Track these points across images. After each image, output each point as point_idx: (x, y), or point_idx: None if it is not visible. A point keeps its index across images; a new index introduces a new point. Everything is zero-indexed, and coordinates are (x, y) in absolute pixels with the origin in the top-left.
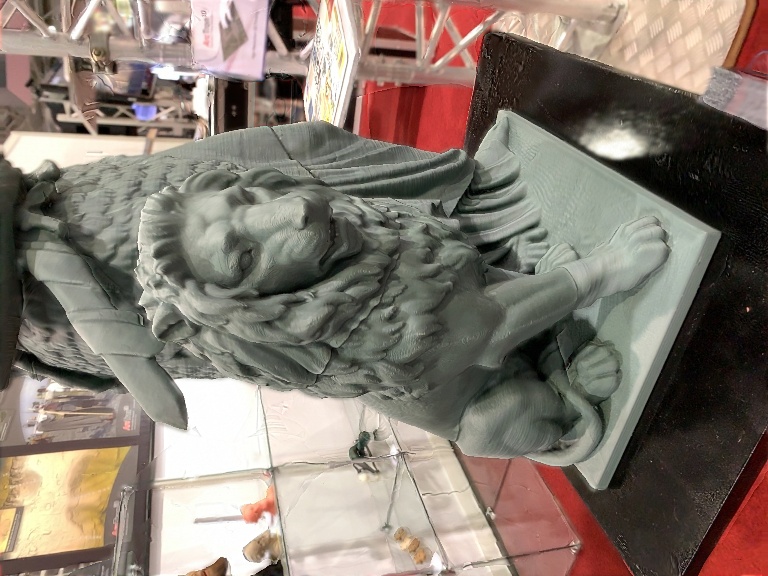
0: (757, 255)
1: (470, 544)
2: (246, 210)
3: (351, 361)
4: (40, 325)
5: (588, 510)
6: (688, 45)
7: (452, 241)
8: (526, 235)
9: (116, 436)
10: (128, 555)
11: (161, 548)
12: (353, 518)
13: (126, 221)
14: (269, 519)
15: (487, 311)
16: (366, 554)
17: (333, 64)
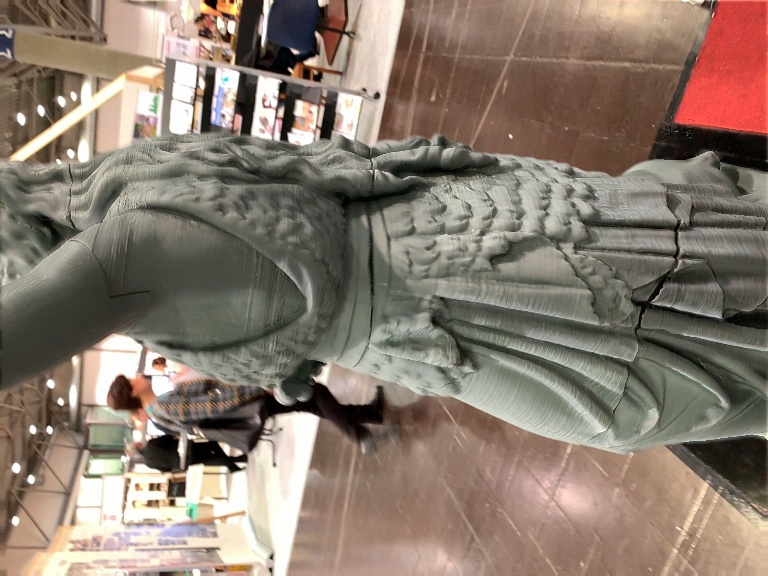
0: None
1: None
2: None
3: None
4: None
5: None
6: None
7: None
8: None
9: None
10: None
11: None
12: None
13: None
14: None
15: None
16: None
17: None
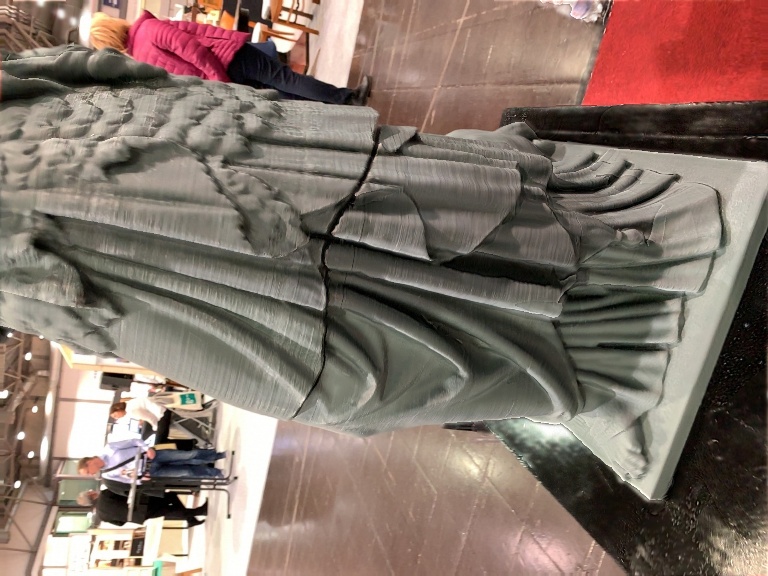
0: None
1: None
2: None
3: None
4: None
5: None
6: None
7: None
8: None
9: None
10: None
11: None
12: None
13: None
14: None
15: None
16: None
17: None
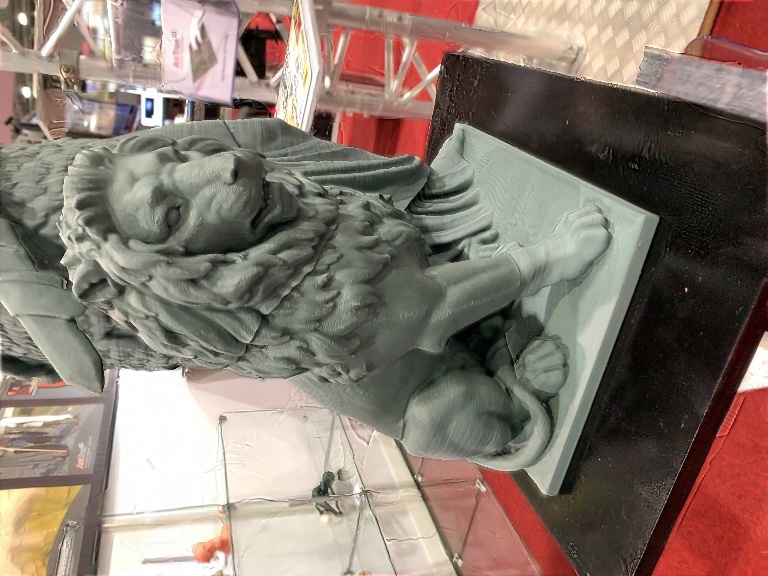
0: (693, 235)
1: None
2: (176, 166)
3: (282, 330)
4: None
5: (555, 551)
6: None
7: (393, 219)
8: (478, 237)
9: (68, 474)
10: None
11: None
12: (314, 564)
13: (60, 191)
14: (223, 560)
15: (426, 288)
16: None
17: (299, 84)
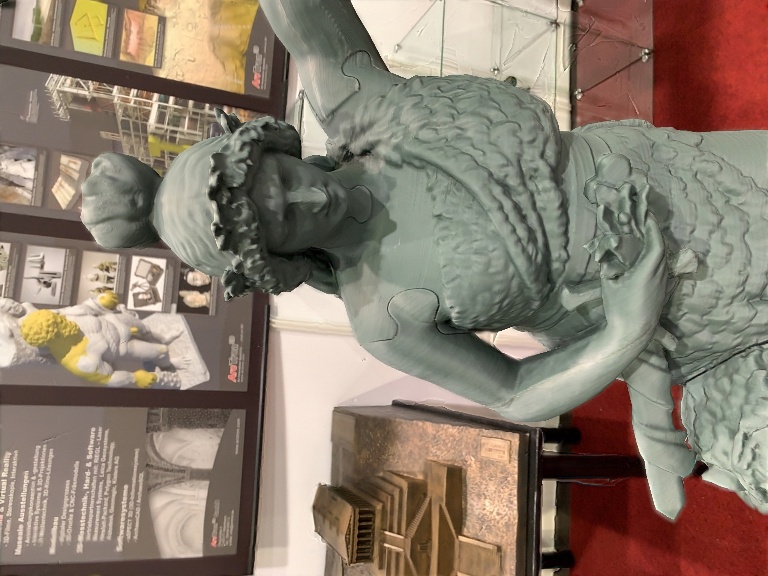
0: None
1: None
2: None
3: None
4: None
5: None
6: None
7: None
8: None
9: None
10: None
11: (294, 114)
12: None
13: (717, 332)
14: None
15: None
16: None
17: None
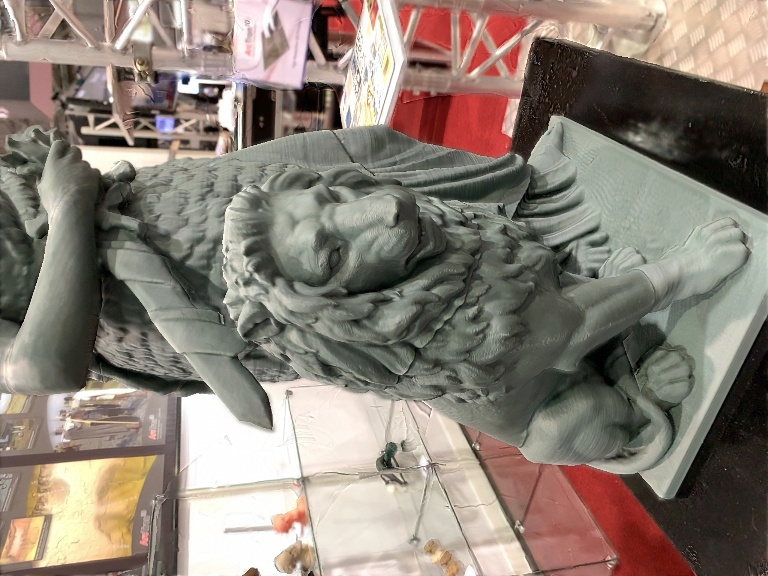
0: None
1: (499, 558)
2: (335, 208)
3: (434, 362)
4: (115, 325)
5: (625, 524)
6: (731, 53)
7: (529, 242)
8: (586, 239)
9: (142, 445)
10: (158, 564)
11: (188, 558)
12: (380, 530)
13: (201, 221)
14: (299, 530)
15: (567, 312)
16: (394, 567)
17: (377, 72)
